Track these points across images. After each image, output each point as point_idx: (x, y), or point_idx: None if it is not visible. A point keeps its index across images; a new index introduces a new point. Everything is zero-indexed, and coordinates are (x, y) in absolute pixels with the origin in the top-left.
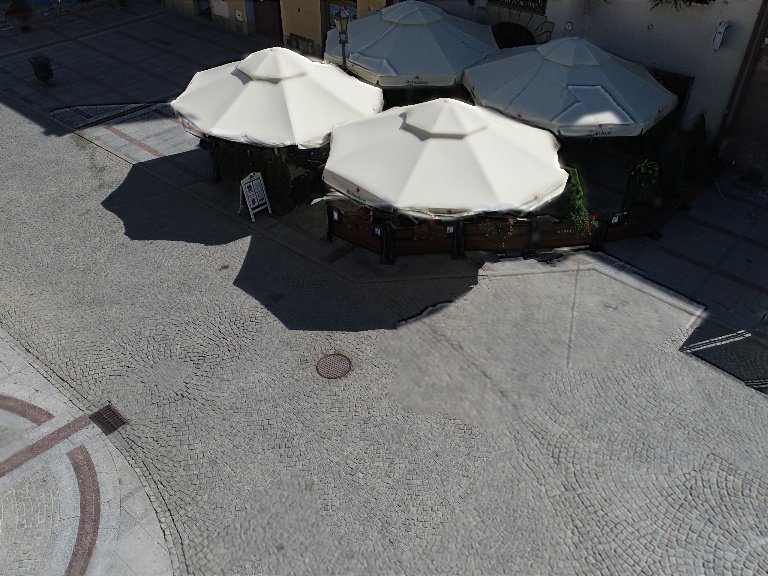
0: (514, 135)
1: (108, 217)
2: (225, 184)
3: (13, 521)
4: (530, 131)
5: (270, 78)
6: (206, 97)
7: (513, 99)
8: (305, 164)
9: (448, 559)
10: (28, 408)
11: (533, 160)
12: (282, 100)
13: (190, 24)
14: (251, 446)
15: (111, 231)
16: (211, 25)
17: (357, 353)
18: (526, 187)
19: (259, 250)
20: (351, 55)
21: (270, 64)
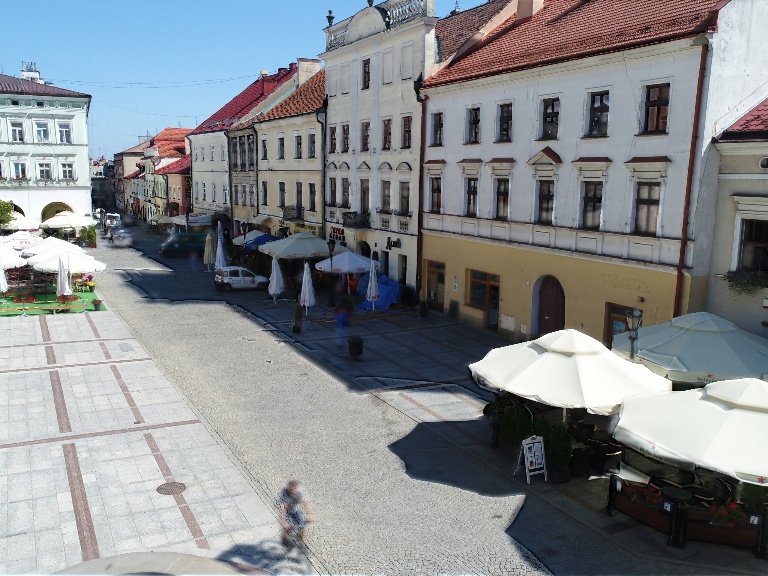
0: None
1: (392, 457)
2: (502, 450)
3: None
4: None
5: (565, 351)
6: (502, 362)
7: None
8: (585, 441)
9: None
10: None
11: None
12: (575, 370)
13: (478, 334)
14: None
15: (394, 468)
16: (496, 336)
17: None
18: None
19: (533, 508)
20: (640, 351)
21: (566, 340)
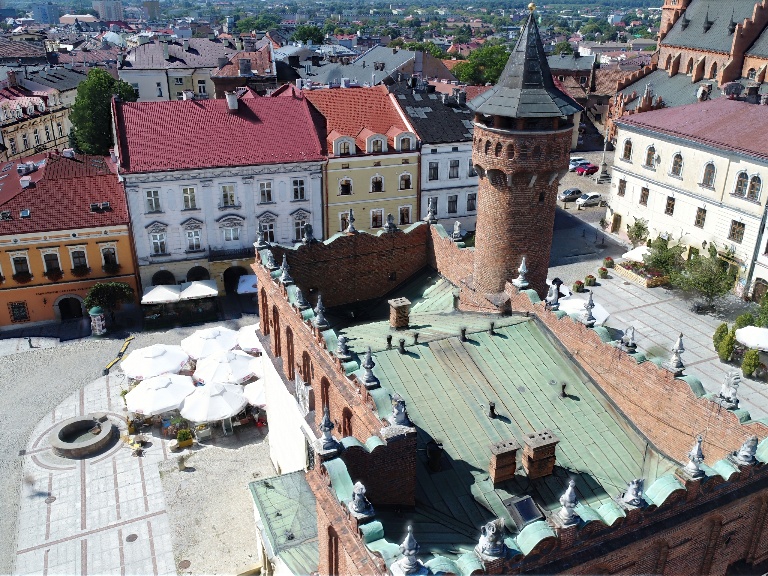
0: None
1: None
2: None
3: None
4: None
5: None
6: None
7: None
8: None
9: (4, 410)
10: None
11: None
12: None
13: None
14: (7, 436)
15: None
16: None
17: None
18: None
19: None
20: None
21: None
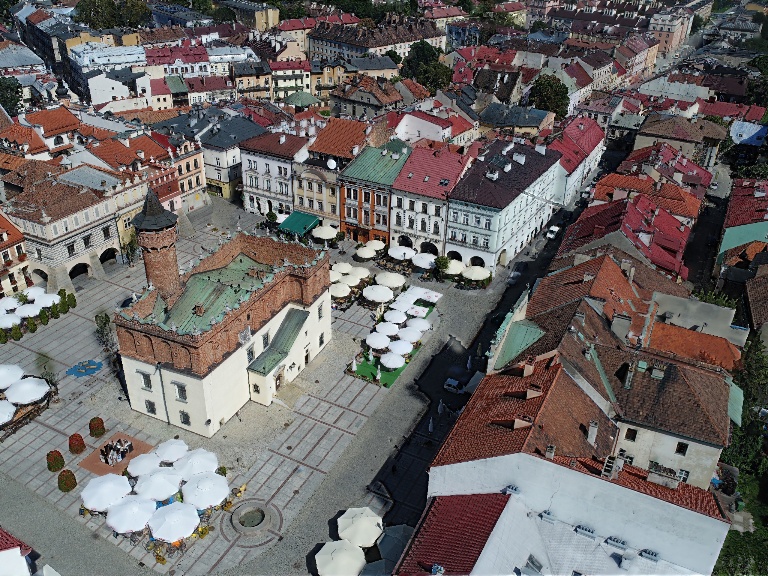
0: (349, 571)
1: None
2: None
3: (261, 536)
4: (355, 575)
5: None
6: None
7: (366, 569)
8: None
9: None
10: (281, 527)
11: (336, 575)
12: None
13: None
14: None
15: None
16: None
17: (301, 568)
18: (328, 575)
19: None
20: None
21: None
